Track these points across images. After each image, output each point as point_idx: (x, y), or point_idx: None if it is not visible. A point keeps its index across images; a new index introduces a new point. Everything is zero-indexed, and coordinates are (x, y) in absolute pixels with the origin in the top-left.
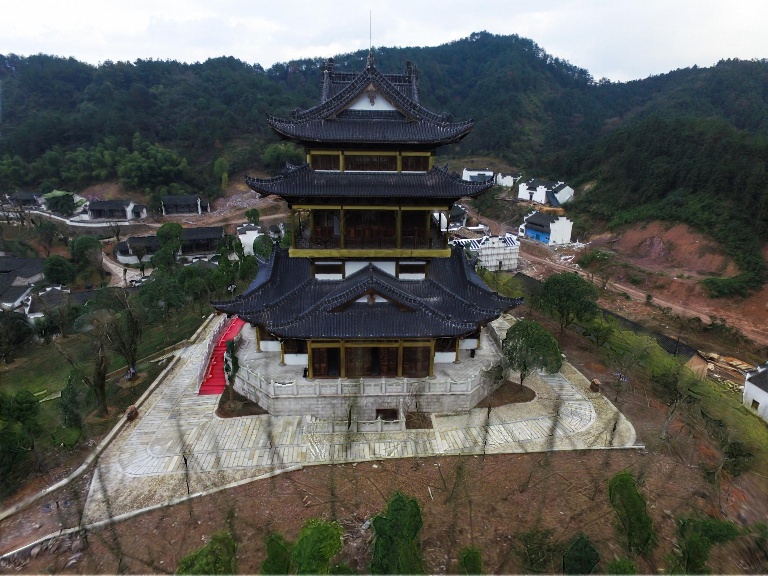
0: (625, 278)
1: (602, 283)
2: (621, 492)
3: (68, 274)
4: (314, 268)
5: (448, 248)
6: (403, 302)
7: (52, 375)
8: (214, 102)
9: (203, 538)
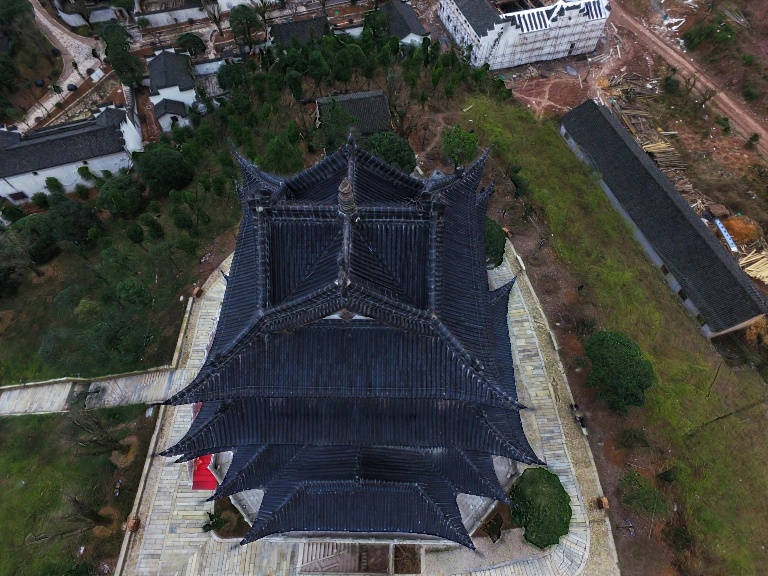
0: (739, 85)
1: (702, 99)
2: None
3: (6, 72)
4: None
5: None
6: (397, 491)
7: None
8: None
9: None
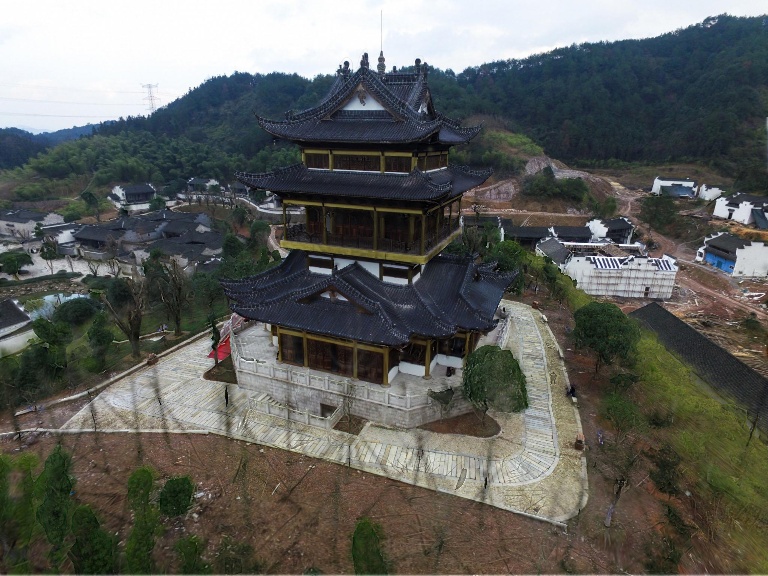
0: None
1: None
2: (354, 540)
3: (238, 250)
4: (308, 260)
5: (425, 255)
6: (361, 303)
7: (161, 323)
8: None
9: (91, 462)
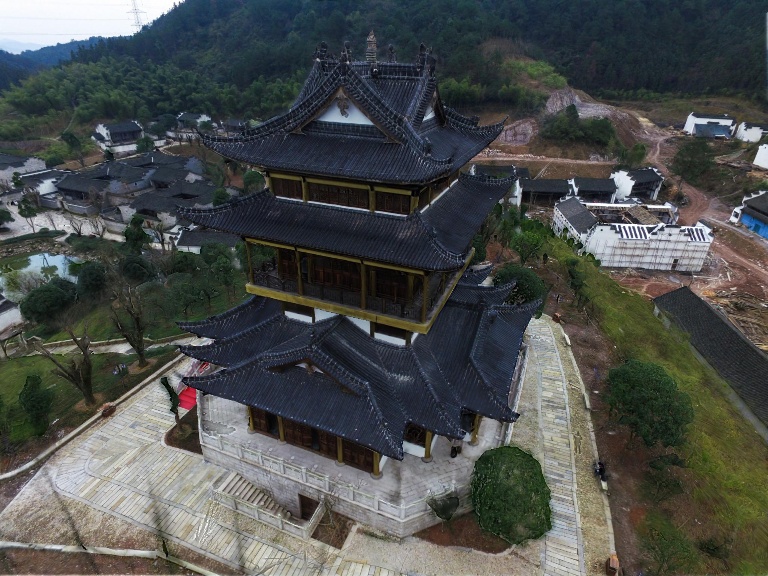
0: None
1: None
2: None
3: None
4: (283, 304)
5: (426, 321)
6: (345, 383)
7: None
8: (402, 29)
9: None
